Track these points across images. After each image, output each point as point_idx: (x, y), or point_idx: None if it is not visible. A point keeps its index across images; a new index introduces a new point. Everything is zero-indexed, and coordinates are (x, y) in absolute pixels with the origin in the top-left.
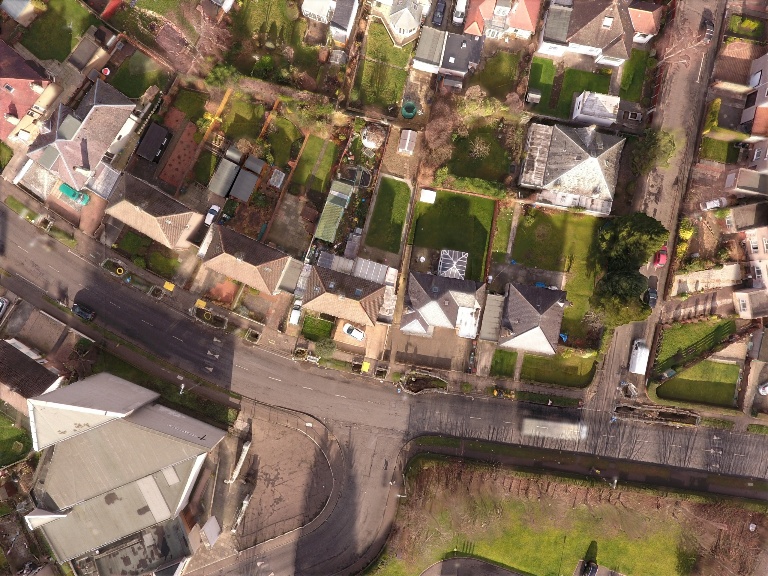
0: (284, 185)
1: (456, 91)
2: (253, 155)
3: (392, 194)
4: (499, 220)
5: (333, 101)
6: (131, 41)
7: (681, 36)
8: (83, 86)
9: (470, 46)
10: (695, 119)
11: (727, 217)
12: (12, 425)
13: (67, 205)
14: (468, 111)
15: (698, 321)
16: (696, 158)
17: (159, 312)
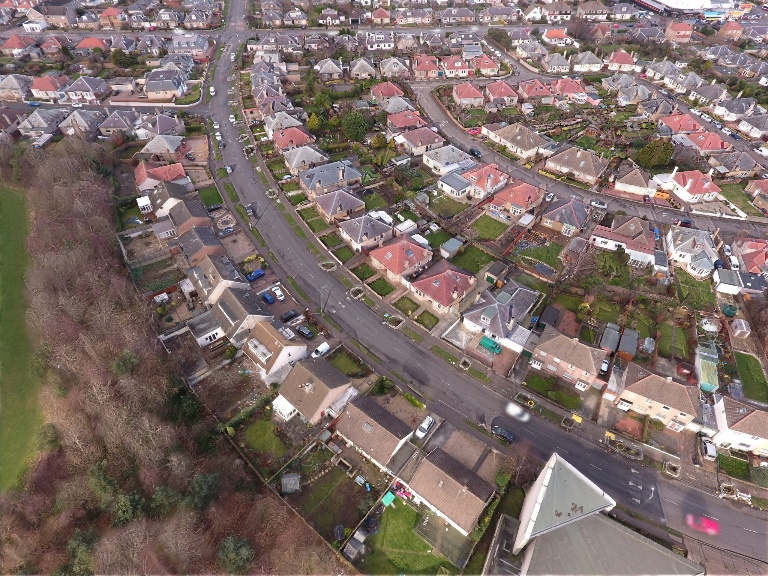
0: (656, 349)
1: None
2: (632, 325)
3: (744, 362)
4: None
5: None
6: (521, 268)
7: None
8: (492, 286)
9: (757, 279)
10: None
11: None
12: (428, 552)
13: (481, 354)
14: None
15: None
16: None
17: (571, 441)
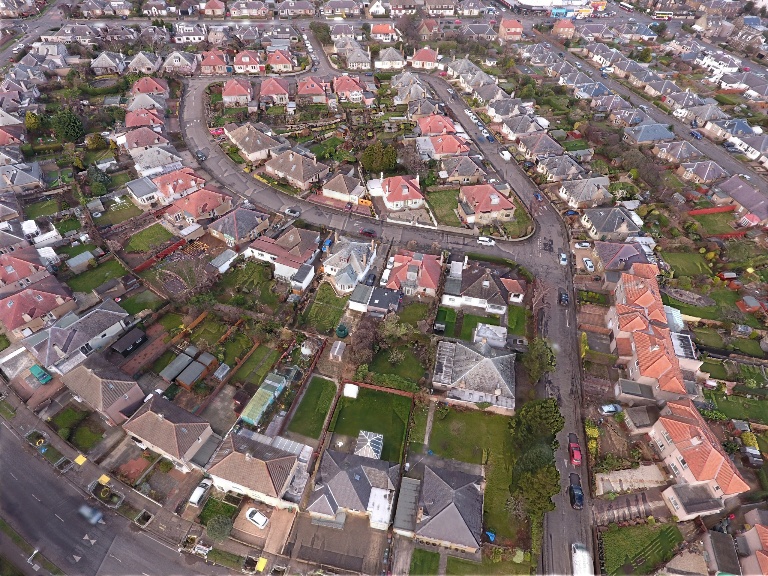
0: (226, 376)
1: (379, 320)
2: (207, 350)
3: (320, 389)
4: (416, 414)
5: (284, 324)
6: (146, 284)
7: (538, 289)
8: None
9: (390, 295)
10: (573, 349)
11: (625, 419)
12: None
13: (28, 384)
14: (387, 329)
15: (636, 524)
16: (583, 375)
17: (55, 487)
